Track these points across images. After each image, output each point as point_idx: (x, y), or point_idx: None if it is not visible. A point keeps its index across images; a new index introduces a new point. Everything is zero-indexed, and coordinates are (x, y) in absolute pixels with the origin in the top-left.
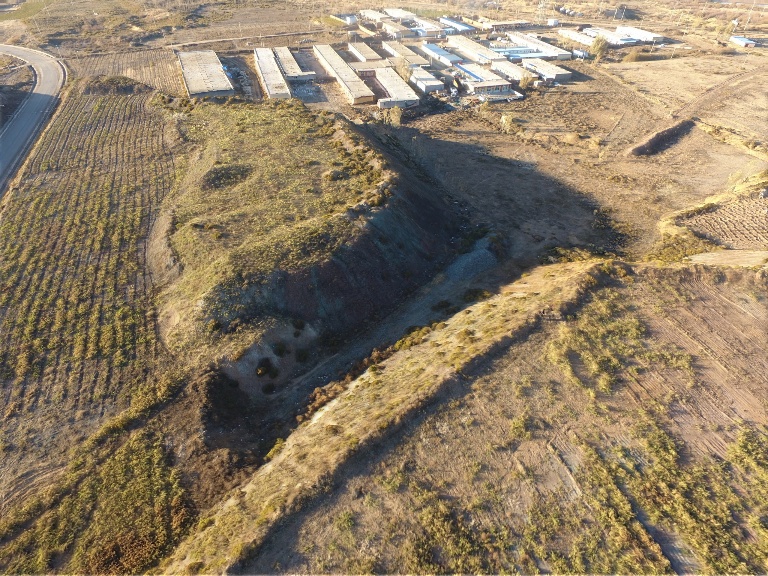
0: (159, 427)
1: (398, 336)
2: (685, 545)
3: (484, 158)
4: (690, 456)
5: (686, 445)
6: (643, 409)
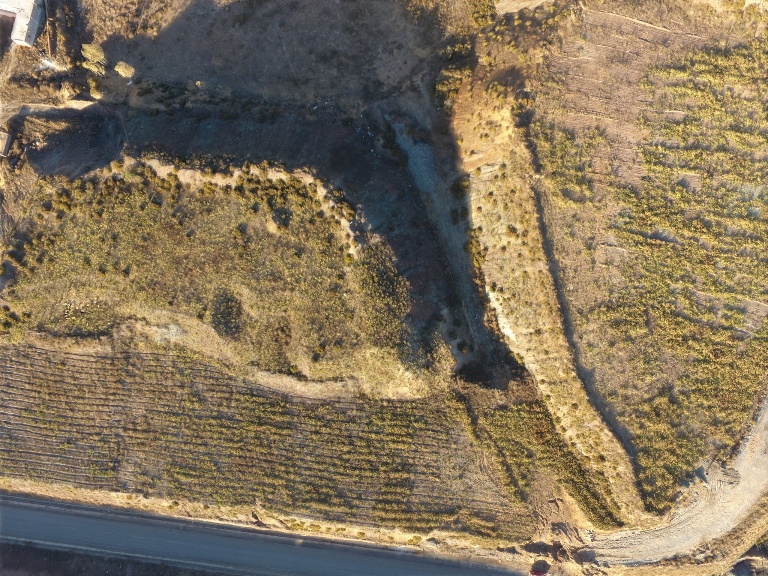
0: (482, 409)
1: (468, 259)
2: (662, 229)
3: (237, 12)
4: (637, 189)
5: (632, 185)
6: (608, 186)
